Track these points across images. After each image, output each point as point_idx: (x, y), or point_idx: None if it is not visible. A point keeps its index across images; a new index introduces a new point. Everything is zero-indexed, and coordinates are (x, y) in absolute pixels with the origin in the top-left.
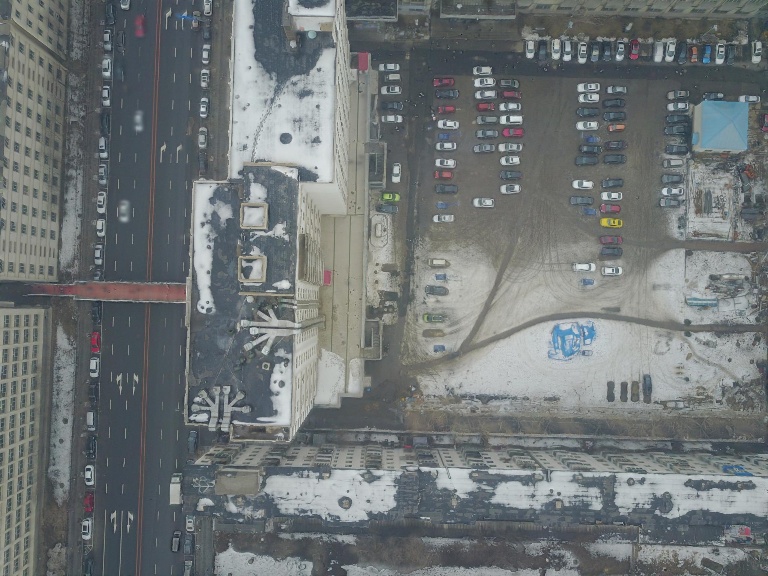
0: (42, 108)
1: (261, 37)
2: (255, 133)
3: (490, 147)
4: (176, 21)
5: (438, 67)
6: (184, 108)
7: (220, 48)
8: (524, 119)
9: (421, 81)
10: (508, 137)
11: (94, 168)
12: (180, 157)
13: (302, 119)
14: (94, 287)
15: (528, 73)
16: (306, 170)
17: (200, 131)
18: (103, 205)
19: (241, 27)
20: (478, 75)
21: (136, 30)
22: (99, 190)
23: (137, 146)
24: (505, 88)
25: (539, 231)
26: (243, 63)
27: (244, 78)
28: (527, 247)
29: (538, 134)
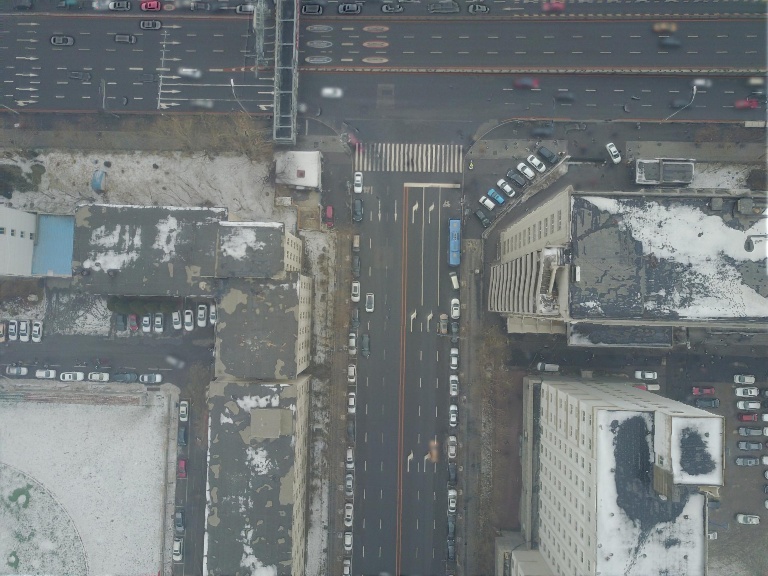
0: None
1: (623, 481)
2: None
3: (755, 461)
4: (421, 323)
5: (696, 373)
6: (431, 414)
7: (467, 351)
8: None
9: (678, 388)
10: None
11: (340, 478)
12: (428, 466)
13: (669, 570)
14: None
15: None
16: None
17: (450, 441)
18: (351, 519)
19: (602, 471)
20: (740, 384)
21: (380, 332)
22: (345, 501)
23: (383, 454)
24: None
25: None
26: (605, 509)
27: (606, 526)
28: None
29: None
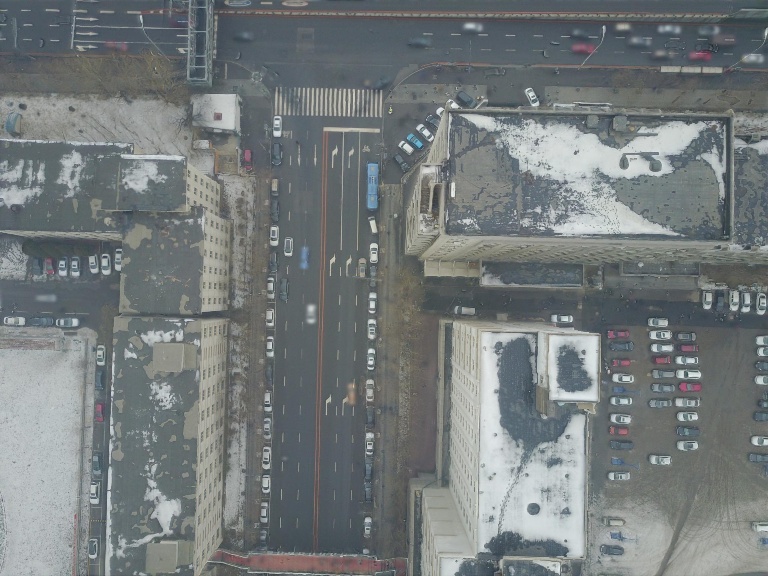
0: (215, 376)
1: (506, 402)
2: (501, 504)
3: (667, 403)
4: (340, 267)
5: (611, 317)
6: (349, 358)
7: (386, 296)
8: (700, 371)
9: (594, 331)
10: (685, 391)
11: (258, 421)
12: (346, 409)
13: (550, 489)
14: (267, 557)
15: (704, 323)
16: (555, 543)
17: (367, 384)
18: (269, 462)
19: (486, 392)
20: (654, 327)
21: (299, 276)
22: (263, 444)
23: (301, 398)
24: (682, 341)
25: (716, 488)
26: (488, 430)
27: (489, 446)
28: (704, 504)
29: (715, 387)
